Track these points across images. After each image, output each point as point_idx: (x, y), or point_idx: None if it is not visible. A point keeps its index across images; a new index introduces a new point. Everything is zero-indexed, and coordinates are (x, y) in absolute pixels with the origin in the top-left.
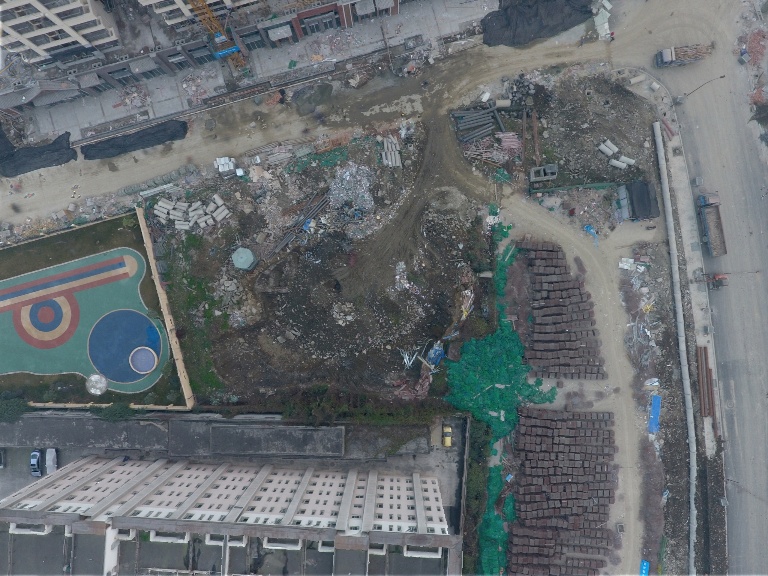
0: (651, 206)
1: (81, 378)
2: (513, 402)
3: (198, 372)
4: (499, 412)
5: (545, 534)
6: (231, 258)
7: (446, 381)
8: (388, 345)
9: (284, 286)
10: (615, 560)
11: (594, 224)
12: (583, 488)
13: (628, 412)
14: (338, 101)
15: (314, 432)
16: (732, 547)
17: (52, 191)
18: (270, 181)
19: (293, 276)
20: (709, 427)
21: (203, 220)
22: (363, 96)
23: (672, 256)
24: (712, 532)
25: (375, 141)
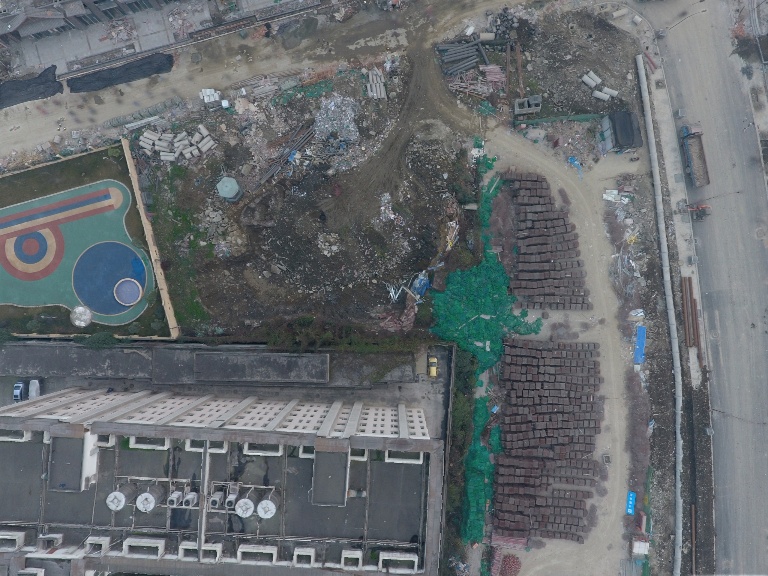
0: (634, 136)
1: (65, 310)
2: (498, 333)
3: (183, 304)
4: (484, 342)
5: (531, 464)
6: (216, 190)
7: (431, 312)
8: (374, 279)
9: (270, 220)
10: (601, 491)
11: (578, 156)
12: (569, 417)
13: (613, 343)
14: (323, 35)
15: (298, 359)
16: (718, 477)
17: (38, 124)
18: (256, 113)
19: (279, 209)
20: (694, 357)
21: (188, 151)
22: (348, 30)
23: (656, 187)
24: (698, 462)
25: (360, 74)
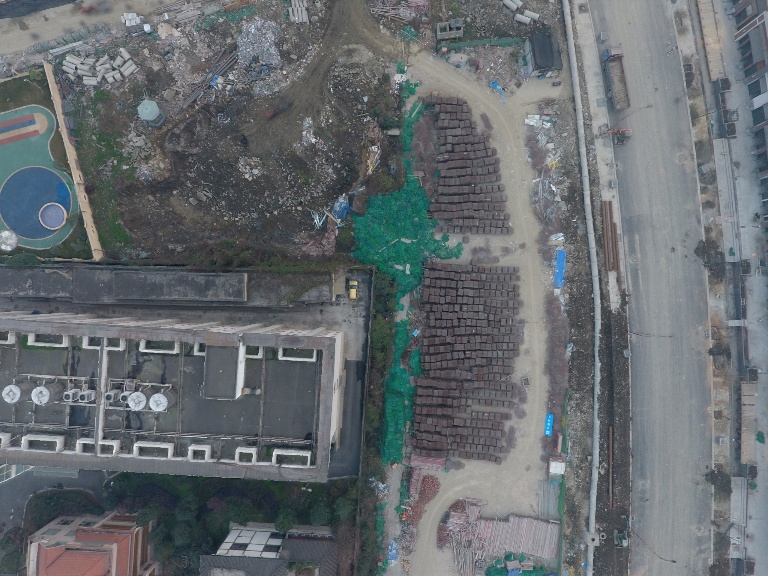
0: (554, 58)
1: None
2: (419, 256)
3: (107, 228)
4: (404, 265)
5: (449, 385)
6: None
7: (352, 235)
8: (299, 206)
9: (195, 147)
10: (520, 413)
11: (500, 81)
12: (487, 339)
13: (534, 267)
14: None
15: (216, 278)
16: (636, 400)
17: None
18: (179, 38)
19: (203, 136)
20: (614, 281)
21: (111, 75)
22: None
23: (577, 111)
24: (616, 384)
25: None
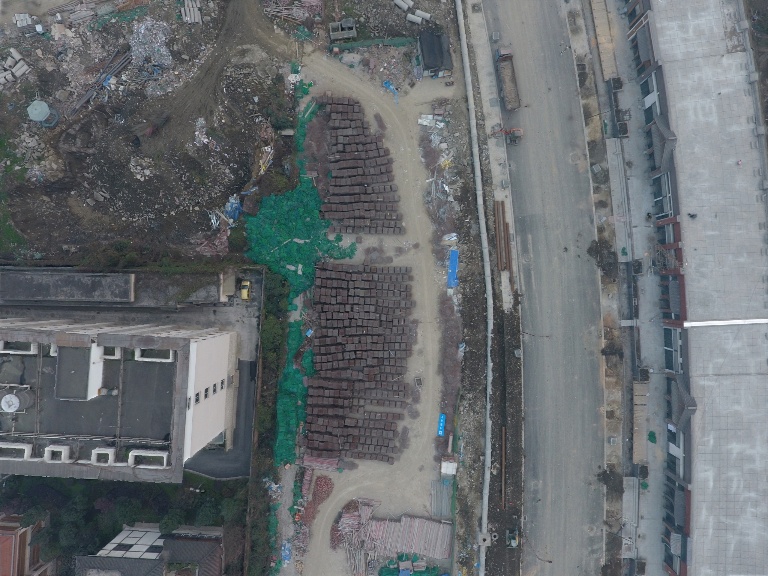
0: (444, 58)
1: None
2: (312, 257)
3: (0, 228)
4: (297, 266)
5: (340, 385)
6: None
7: (245, 236)
8: (196, 207)
9: (92, 147)
10: (413, 413)
11: (394, 81)
12: (378, 339)
13: (427, 267)
14: None
15: (102, 278)
16: (528, 400)
17: None
18: (72, 39)
19: (99, 136)
20: (506, 281)
21: (3, 76)
22: None
23: (470, 111)
24: (508, 384)
25: None
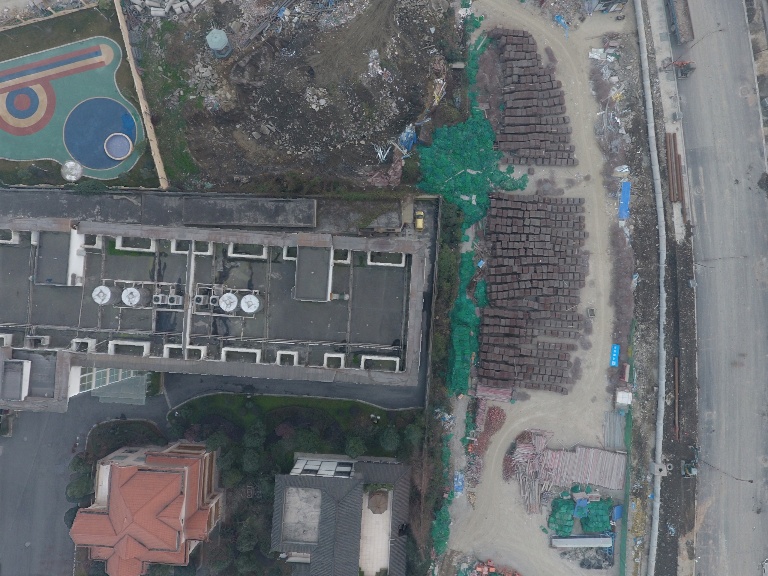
0: None
1: (56, 164)
2: (485, 188)
3: (173, 158)
4: (471, 196)
5: (516, 314)
6: (206, 47)
7: (418, 166)
8: (362, 140)
9: (259, 80)
10: (586, 344)
11: (564, 15)
12: (553, 269)
13: (598, 199)
14: None
15: (286, 203)
16: (701, 330)
17: None
18: None
19: (268, 69)
20: (678, 212)
21: (179, 6)
22: None
23: (641, 45)
24: (681, 315)
25: None
